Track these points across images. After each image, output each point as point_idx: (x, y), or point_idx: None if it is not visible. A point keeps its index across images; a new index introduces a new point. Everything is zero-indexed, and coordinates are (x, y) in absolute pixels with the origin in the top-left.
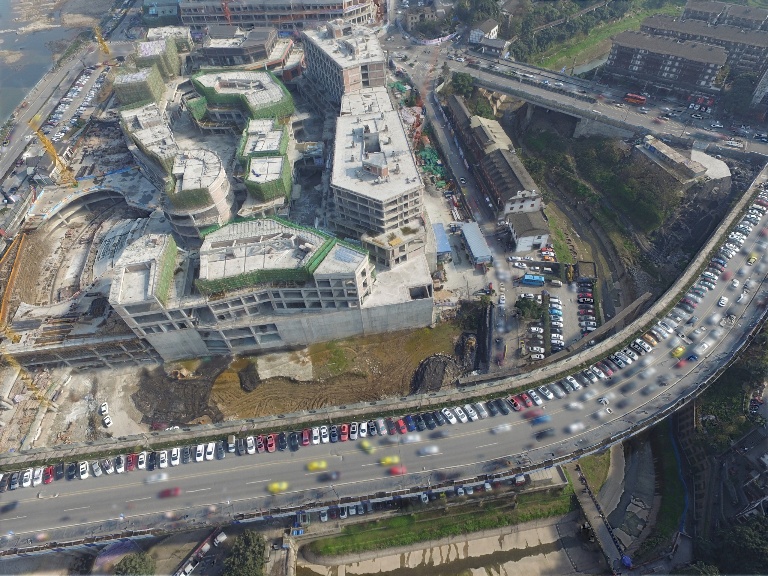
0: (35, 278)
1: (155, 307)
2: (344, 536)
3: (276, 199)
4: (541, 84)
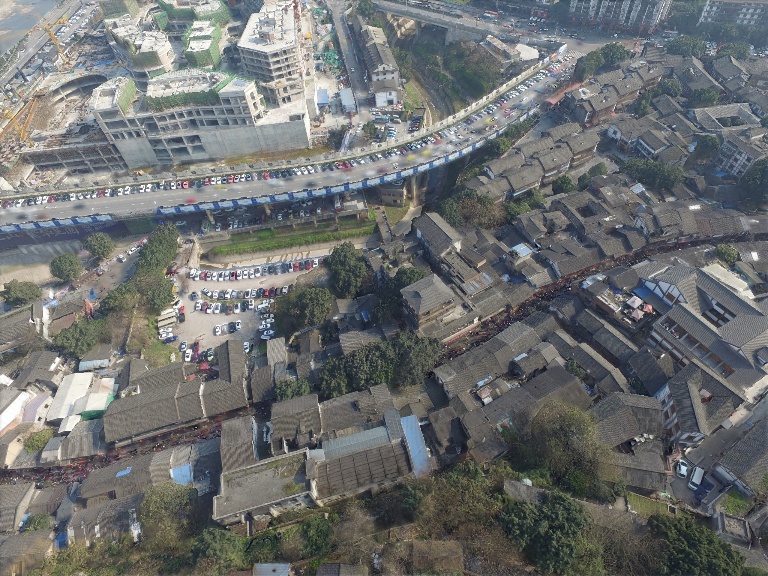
0: (44, 127)
1: (119, 117)
2: (231, 244)
3: (206, 66)
4: (425, 7)
